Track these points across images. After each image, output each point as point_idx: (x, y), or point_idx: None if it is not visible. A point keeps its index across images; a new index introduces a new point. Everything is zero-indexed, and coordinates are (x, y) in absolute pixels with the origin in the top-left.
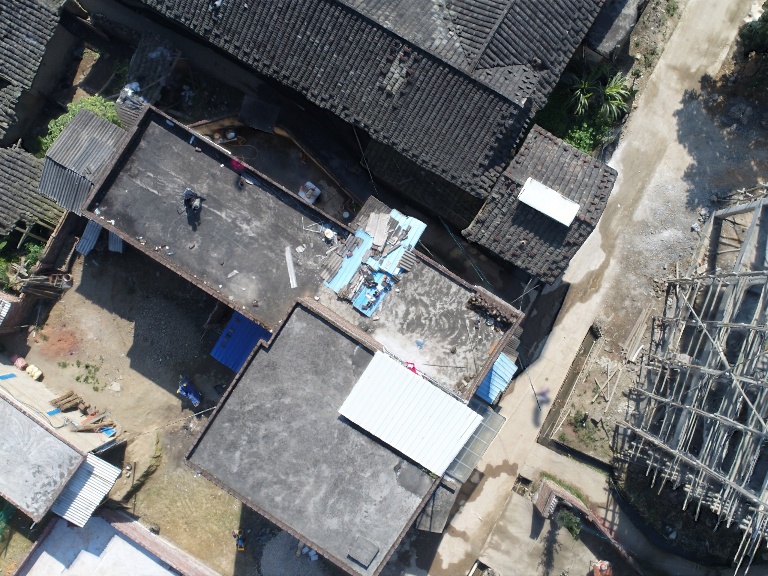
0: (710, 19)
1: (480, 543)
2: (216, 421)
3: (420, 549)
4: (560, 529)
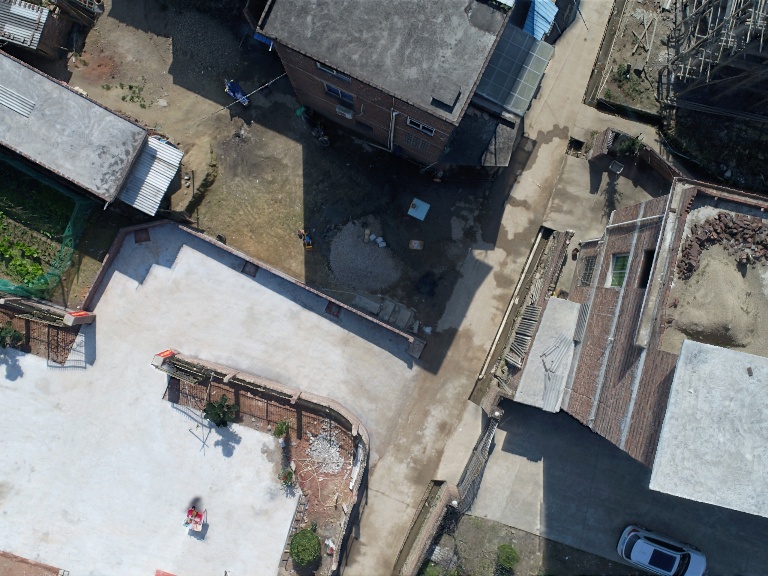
0: None
1: (542, 209)
2: None
3: (484, 223)
4: (618, 179)
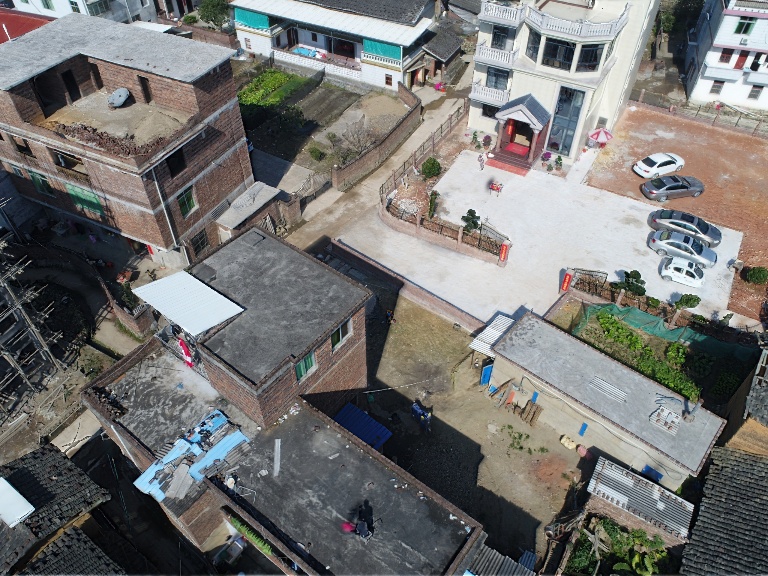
0: None
1: None
2: None
3: None
4: None
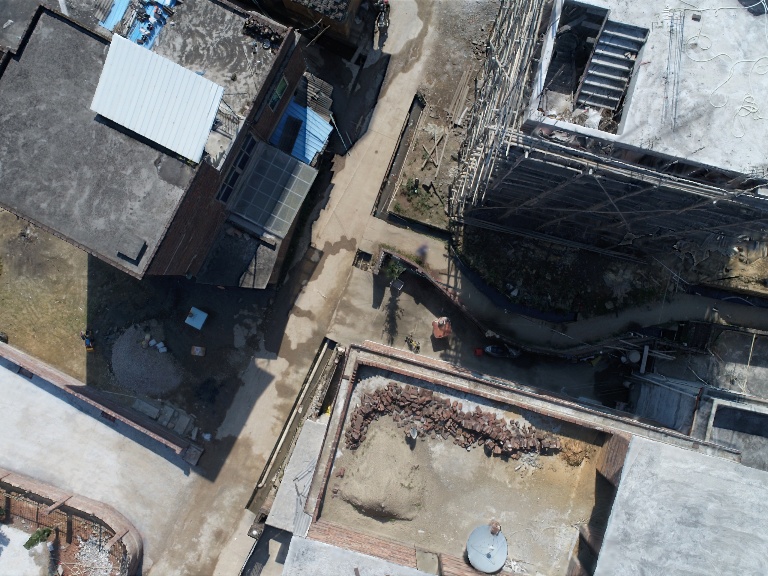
0: None
1: (326, 320)
2: None
3: (267, 332)
4: (400, 295)
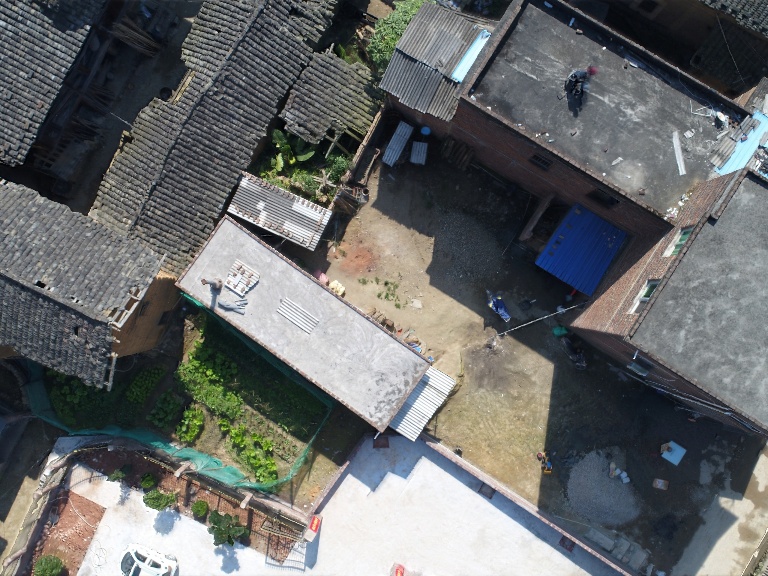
0: None
1: None
2: (659, 299)
3: (735, 471)
4: None
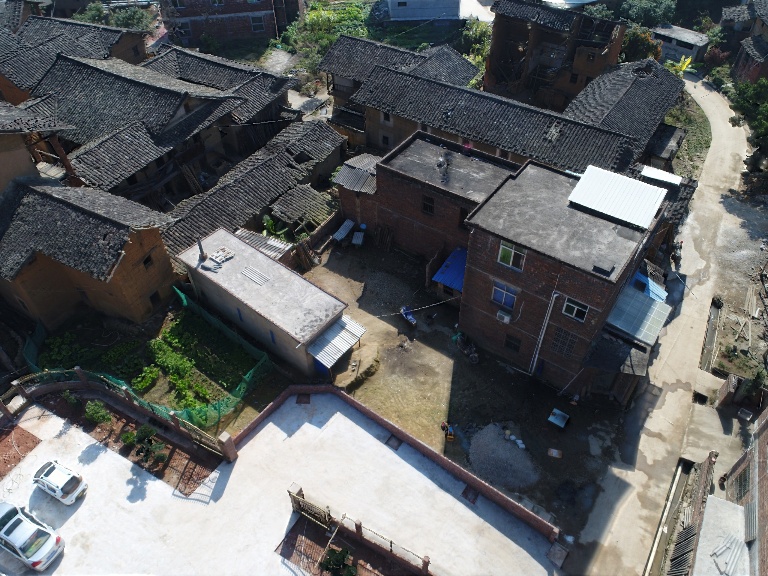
0: (721, 170)
1: (678, 443)
2: (485, 206)
3: (621, 446)
4: (750, 425)
